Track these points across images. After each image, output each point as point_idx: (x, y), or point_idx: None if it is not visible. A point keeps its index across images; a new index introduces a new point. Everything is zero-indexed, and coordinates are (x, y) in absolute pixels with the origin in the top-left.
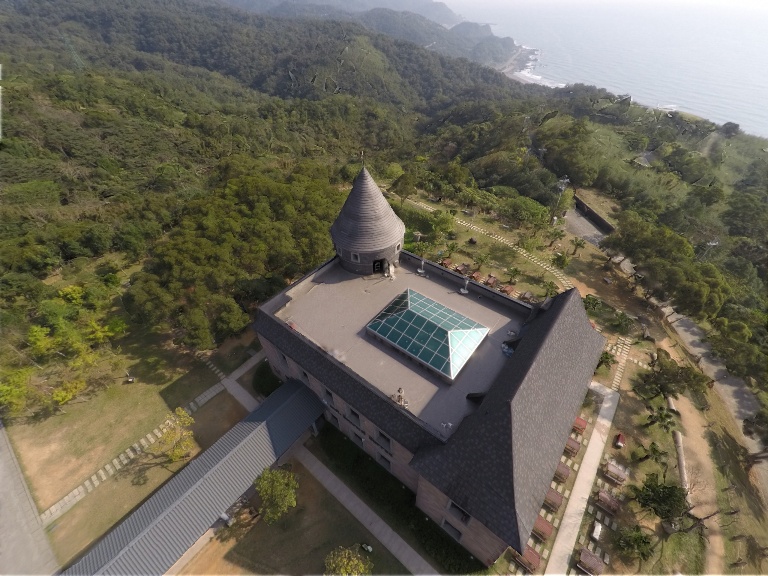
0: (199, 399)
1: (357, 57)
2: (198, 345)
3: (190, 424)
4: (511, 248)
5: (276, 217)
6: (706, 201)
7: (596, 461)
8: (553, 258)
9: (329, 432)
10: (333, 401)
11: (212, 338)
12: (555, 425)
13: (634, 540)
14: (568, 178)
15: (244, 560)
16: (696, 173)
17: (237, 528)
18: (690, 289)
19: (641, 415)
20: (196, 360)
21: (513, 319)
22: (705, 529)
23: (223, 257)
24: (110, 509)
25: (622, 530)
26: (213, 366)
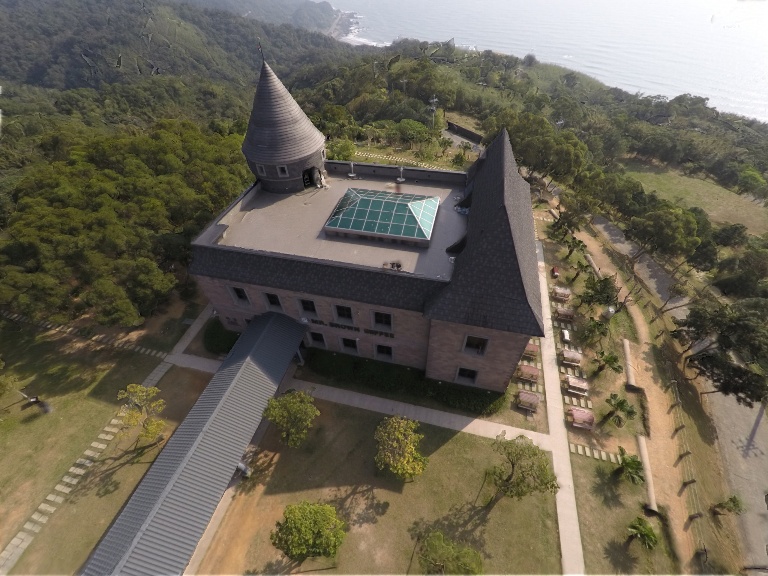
0: (145, 385)
1: (167, 29)
2: (121, 320)
3: (155, 393)
4: (411, 164)
5: (156, 175)
6: (537, 106)
7: (545, 291)
8: (452, 159)
9: (315, 355)
10: (316, 311)
11: (135, 310)
12: (526, 243)
13: (594, 326)
14: (436, 97)
15: (281, 496)
16: (523, 88)
17: (258, 475)
18: (561, 150)
19: (561, 252)
20: (119, 351)
21: (453, 189)
22: (628, 307)
23: (110, 219)
24: (81, 533)
25: (584, 324)
26: (145, 350)
